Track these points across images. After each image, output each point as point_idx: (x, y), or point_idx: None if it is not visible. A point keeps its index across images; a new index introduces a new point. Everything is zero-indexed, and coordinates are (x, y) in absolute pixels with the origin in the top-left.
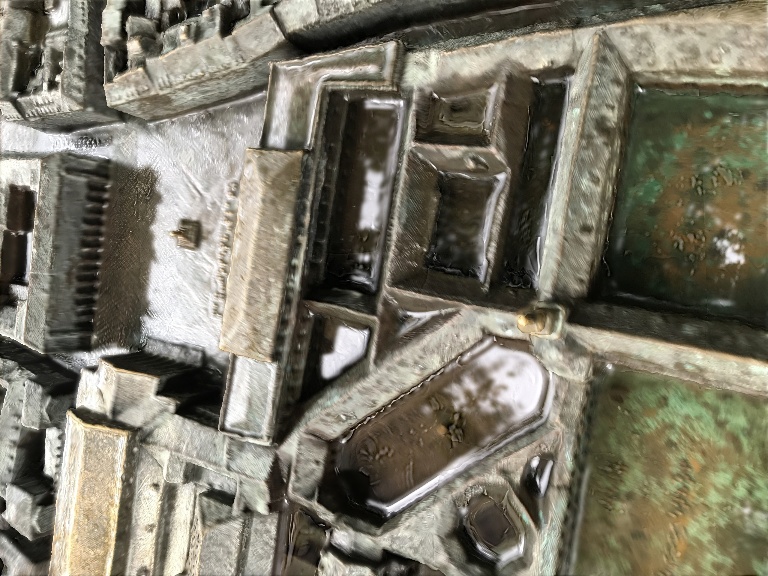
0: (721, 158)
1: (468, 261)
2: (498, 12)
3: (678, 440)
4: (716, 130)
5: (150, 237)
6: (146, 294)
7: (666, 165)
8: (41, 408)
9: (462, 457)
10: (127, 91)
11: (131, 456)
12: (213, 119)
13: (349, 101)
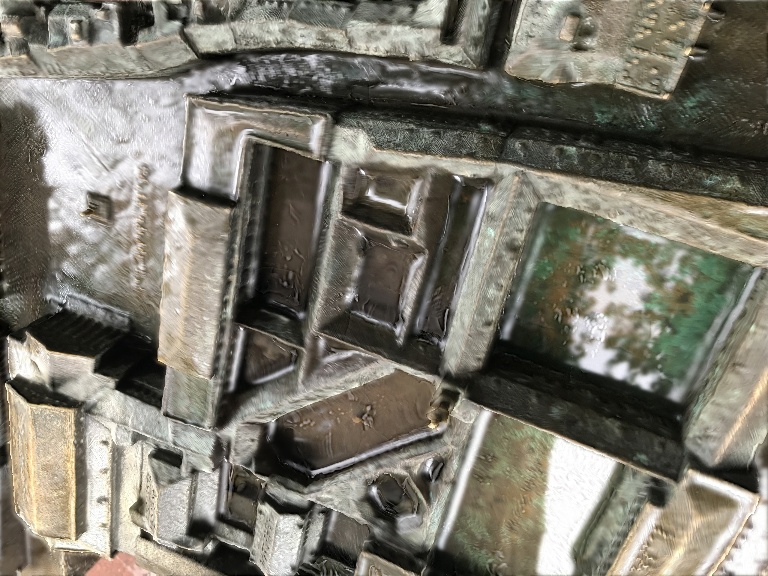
0: (603, 257)
1: (384, 300)
2: (426, 67)
3: (535, 446)
4: (604, 233)
5: (54, 200)
6: (58, 254)
7: (559, 252)
8: None
9: (373, 443)
10: (8, 70)
11: (79, 425)
12: (112, 92)
13: None
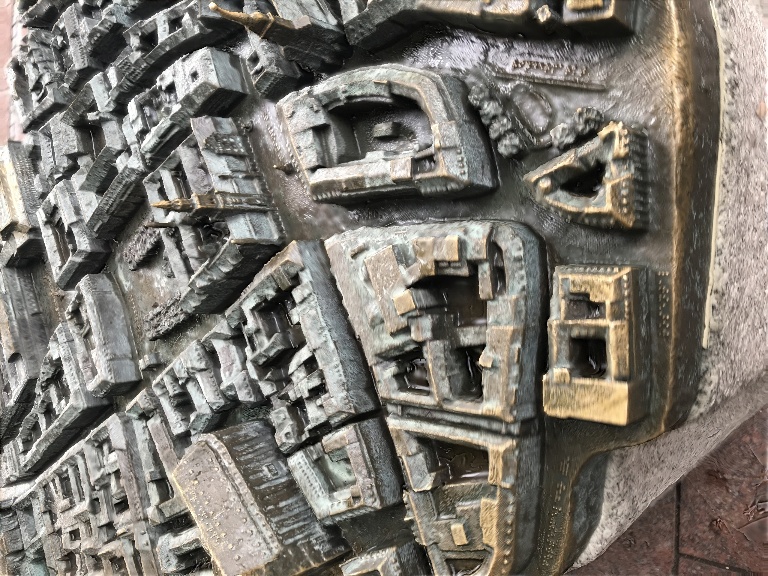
0: None
1: None
2: None
3: None
4: None
5: None
6: None
7: None
8: None
9: None
10: None
11: None
12: None
13: None
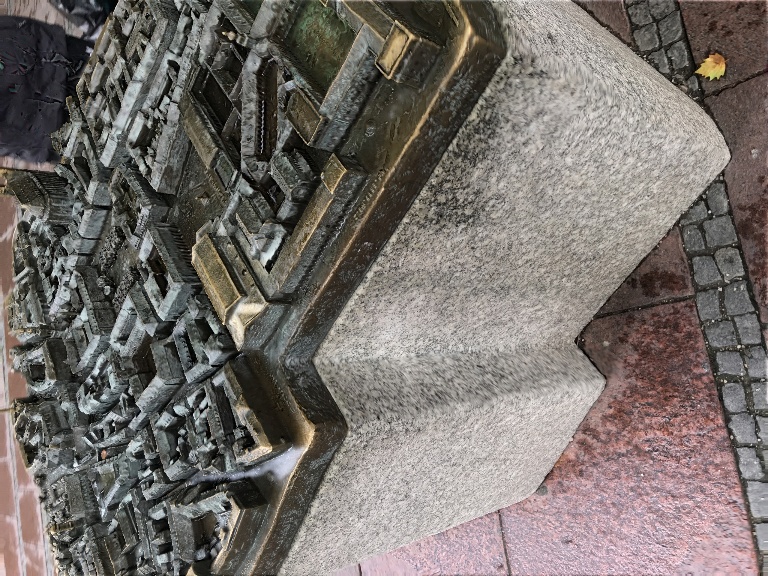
0: None
1: None
2: None
3: None
4: None
5: (198, 221)
6: None
7: None
8: (195, 301)
9: None
10: (157, 176)
11: (213, 240)
12: (190, 165)
13: (202, 92)
